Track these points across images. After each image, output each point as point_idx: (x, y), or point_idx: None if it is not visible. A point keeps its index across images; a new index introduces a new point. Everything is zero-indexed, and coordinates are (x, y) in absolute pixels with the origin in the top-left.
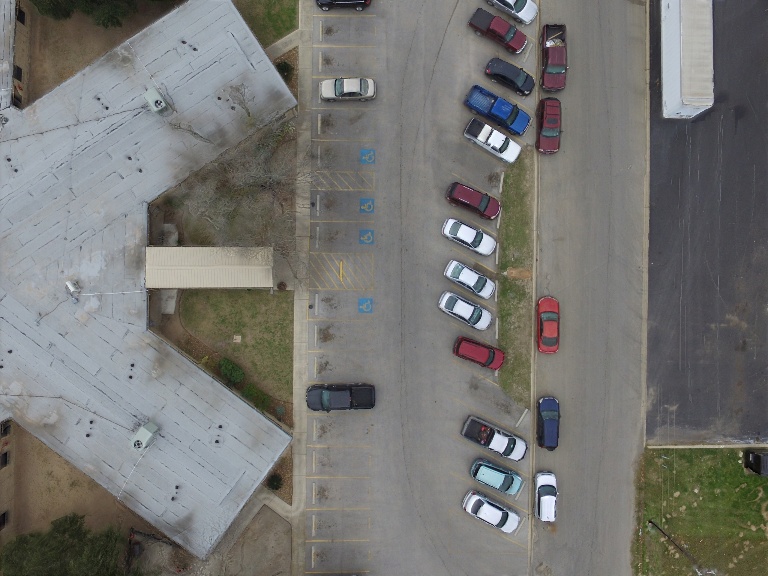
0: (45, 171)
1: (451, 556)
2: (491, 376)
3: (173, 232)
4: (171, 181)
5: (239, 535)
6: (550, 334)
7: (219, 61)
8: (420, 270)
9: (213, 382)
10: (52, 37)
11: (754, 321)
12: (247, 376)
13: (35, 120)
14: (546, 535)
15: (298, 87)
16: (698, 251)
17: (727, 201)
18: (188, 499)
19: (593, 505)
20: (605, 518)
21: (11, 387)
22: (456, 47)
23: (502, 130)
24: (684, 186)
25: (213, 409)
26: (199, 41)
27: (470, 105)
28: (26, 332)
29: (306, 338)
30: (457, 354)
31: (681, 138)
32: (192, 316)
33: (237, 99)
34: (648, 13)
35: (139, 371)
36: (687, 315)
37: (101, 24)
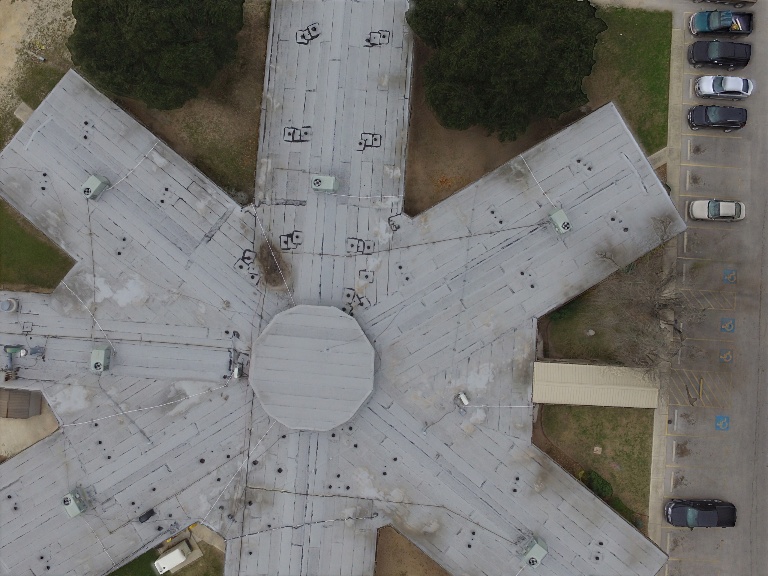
0: (438, 281)
1: None
2: None
3: (538, 341)
4: (561, 298)
5: None
6: None
7: (615, 183)
8: None
9: (595, 499)
10: (421, 138)
11: None
12: None
13: (426, 229)
14: None
15: None
16: None
17: None
18: None
19: None
20: None
21: (393, 494)
22: None
23: None
24: None
25: (594, 526)
26: (592, 160)
27: None
28: (414, 441)
29: (664, 453)
30: None
31: None
32: (554, 425)
33: (661, 232)
34: None
35: (522, 485)
36: None
37: (491, 136)
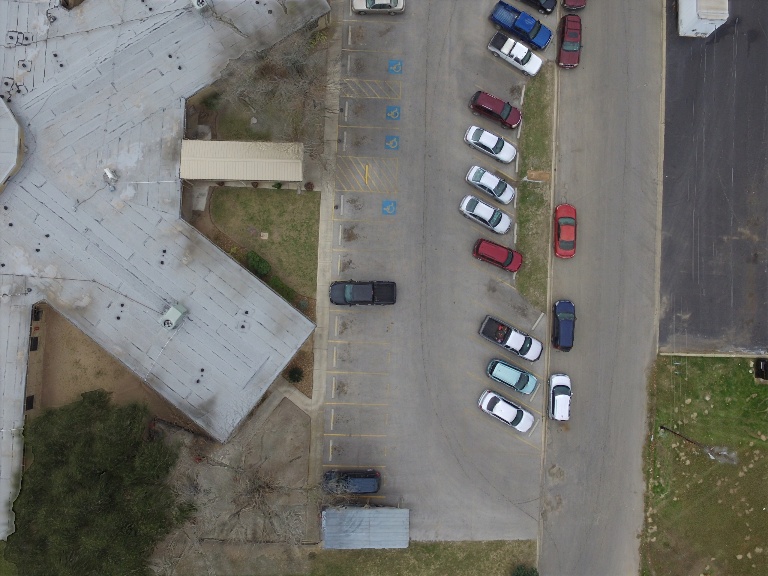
0: (89, 66)
1: (466, 455)
2: (509, 280)
3: (206, 133)
4: (208, 78)
5: (259, 426)
6: (567, 238)
7: None
8: (442, 175)
9: (241, 270)
10: None
11: (765, 235)
12: (273, 272)
13: (81, 19)
14: (559, 437)
15: (331, 0)
16: (711, 166)
17: (739, 120)
18: (213, 382)
19: (606, 409)
20: (618, 422)
21: (46, 270)
22: None
23: (524, 45)
24: (698, 104)
25: (240, 296)
26: None
27: (494, 19)
28: (64, 217)
29: (331, 237)
30: (477, 254)
31: (696, 58)
32: (222, 213)
33: None
34: None
35: (170, 257)
36: (700, 227)
37: None
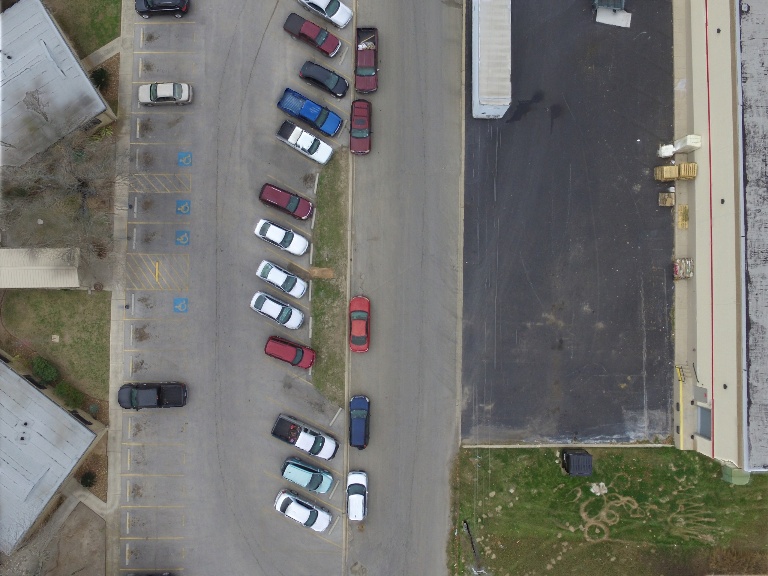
0: None
1: (265, 554)
2: (305, 375)
3: None
4: None
5: (56, 532)
6: (358, 333)
7: (30, 68)
8: (235, 270)
9: (20, 380)
10: None
11: (571, 320)
12: (64, 375)
13: None
14: (361, 534)
15: (118, 92)
16: (513, 250)
17: (543, 200)
18: None
19: (407, 504)
20: (420, 518)
21: None
22: (273, 51)
23: (316, 132)
24: (499, 185)
25: (20, 407)
26: (13, 49)
27: (281, 108)
28: None
29: (122, 337)
30: (266, 353)
31: (495, 138)
32: (13, 316)
33: (31, 104)
34: (464, 15)
35: None
36: (502, 314)
37: None
